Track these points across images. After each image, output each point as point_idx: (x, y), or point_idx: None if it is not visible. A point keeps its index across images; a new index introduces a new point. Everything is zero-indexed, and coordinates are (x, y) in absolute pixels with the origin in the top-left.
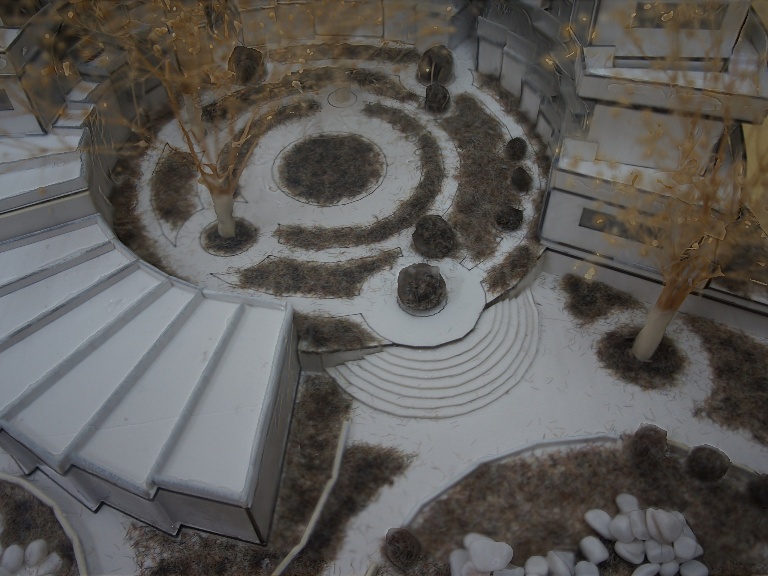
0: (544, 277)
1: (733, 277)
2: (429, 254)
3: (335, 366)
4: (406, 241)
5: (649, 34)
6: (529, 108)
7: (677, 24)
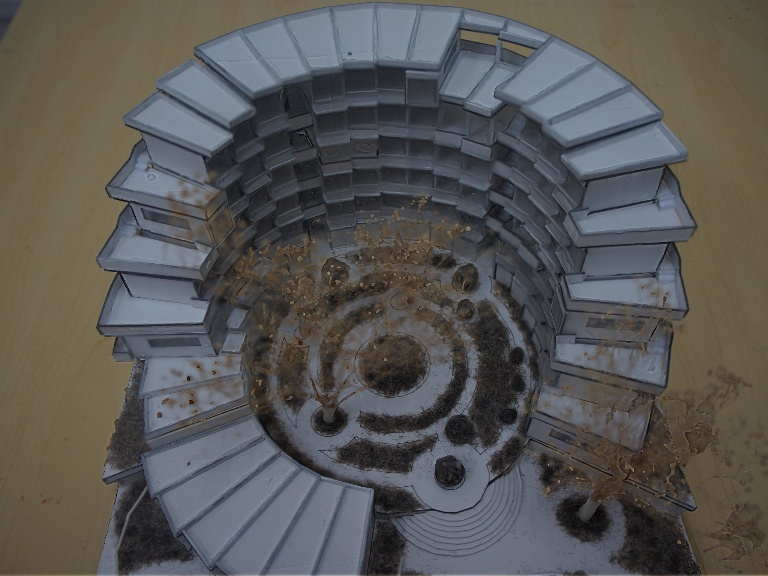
0: (528, 454)
1: (644, 473)
2: (455, 442)
3: (396, 518)
4: (441, 429)
5: (597, 330)
6: (528, 320)
7: (614, 327)
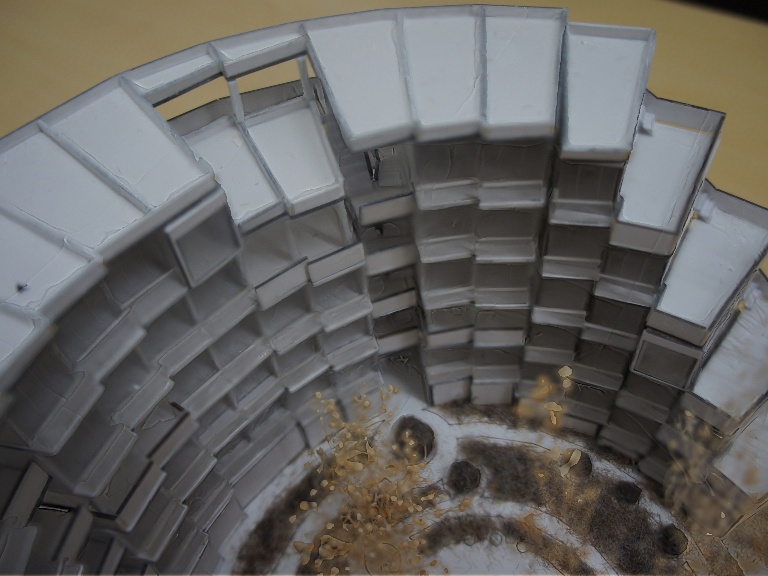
0: None
1: None
2: None
3: None
4: None
5: None
6: (533, 411)
7: None
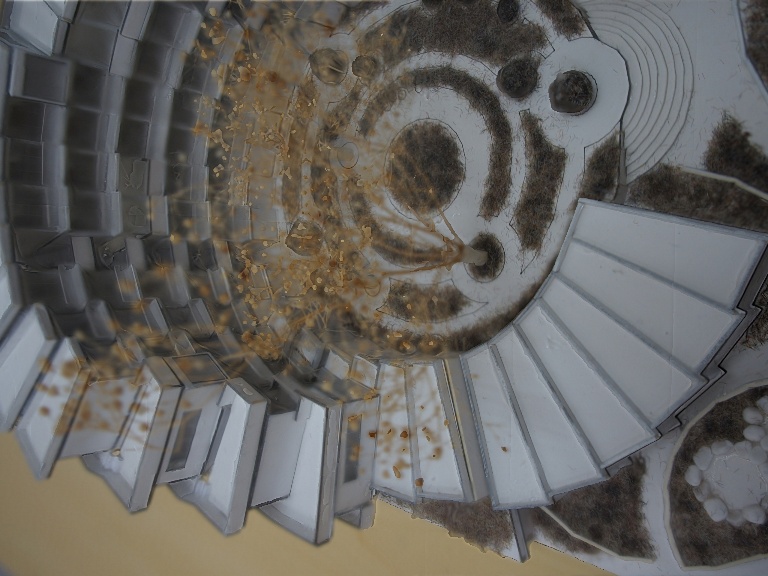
0: None
1: None
2: (533, 85)
3: (626, 175)
4: (513, 105)
5: None
6: None
7: None
